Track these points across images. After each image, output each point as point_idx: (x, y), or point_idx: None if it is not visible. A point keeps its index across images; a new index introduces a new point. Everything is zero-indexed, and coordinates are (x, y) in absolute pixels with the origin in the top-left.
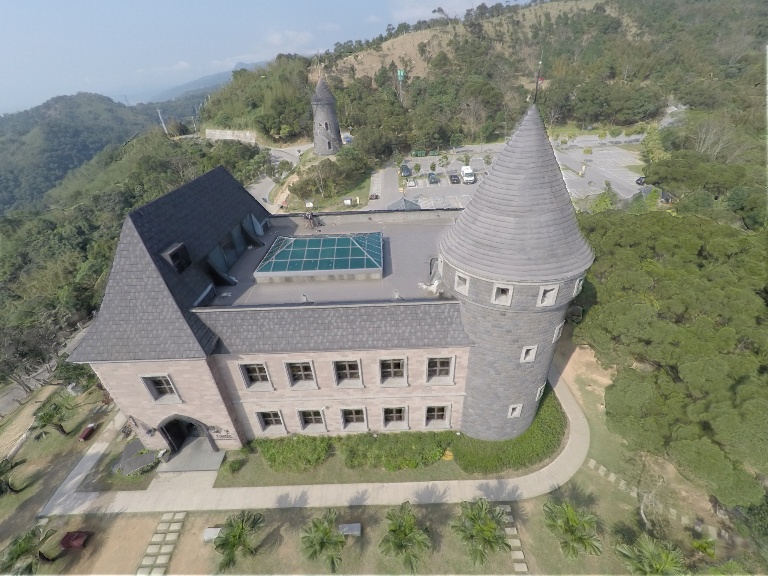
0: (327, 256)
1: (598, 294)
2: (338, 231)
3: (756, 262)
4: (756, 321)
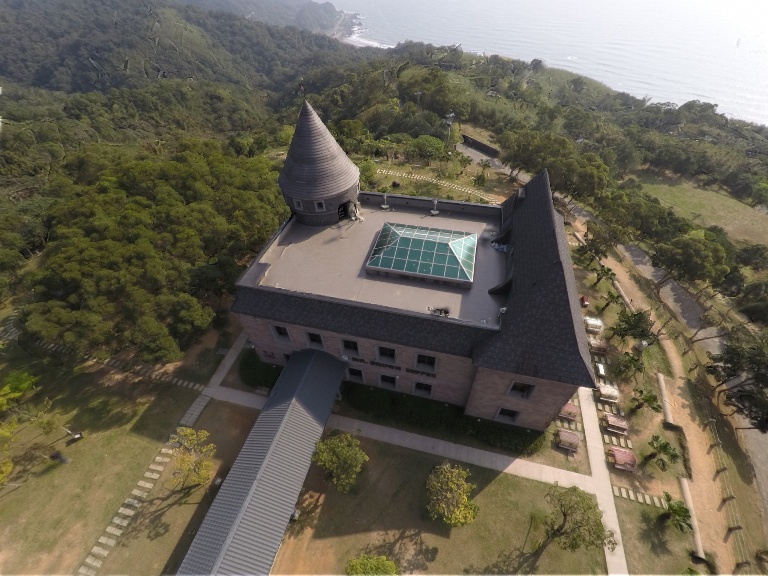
0: (422, 231)
1: (240, 239)
2: (408, 302)
3: (155, 206)
4: (211, 201)
